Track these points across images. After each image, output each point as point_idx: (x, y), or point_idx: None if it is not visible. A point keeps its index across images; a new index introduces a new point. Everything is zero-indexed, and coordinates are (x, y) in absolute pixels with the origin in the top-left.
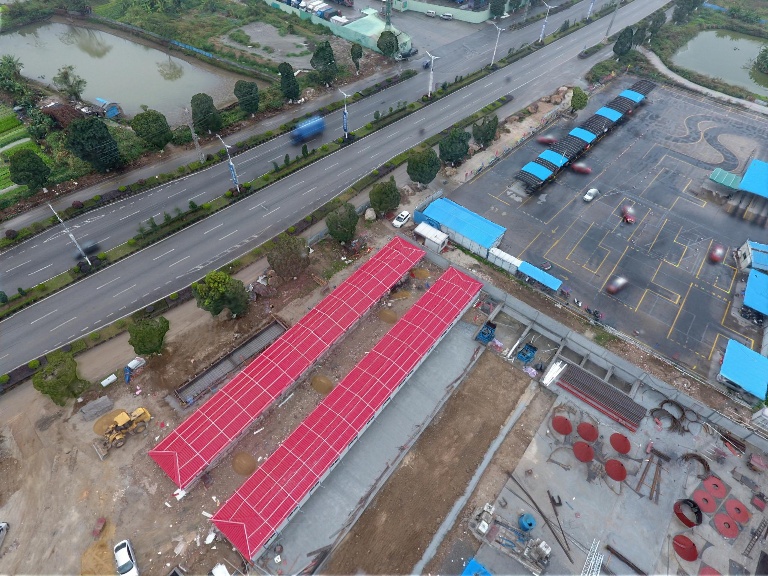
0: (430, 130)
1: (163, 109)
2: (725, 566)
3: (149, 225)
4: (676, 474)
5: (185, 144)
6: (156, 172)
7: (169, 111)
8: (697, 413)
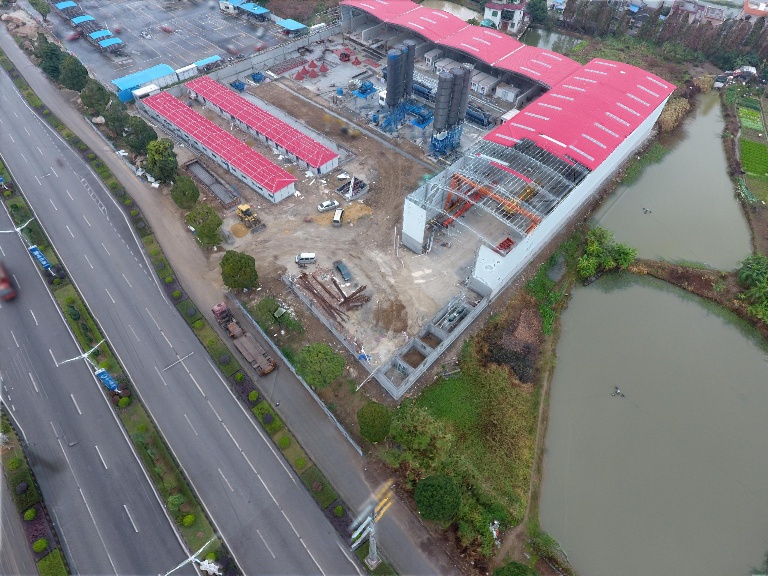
0: (2, 84)
1: None
2: (364, 58)
3: None
4: (330, 57)
5: None
6: None
7: None
8: (306, 45)
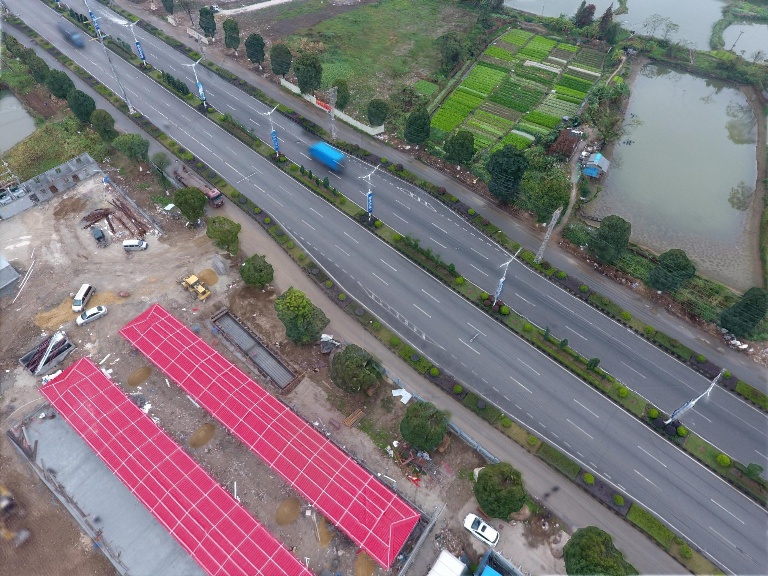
0: None
1: (632, 208)
2: None
3: (414, 242)
4: None
5: (566, 240)
6: (509, 229)
7: (631, 214)
8: None
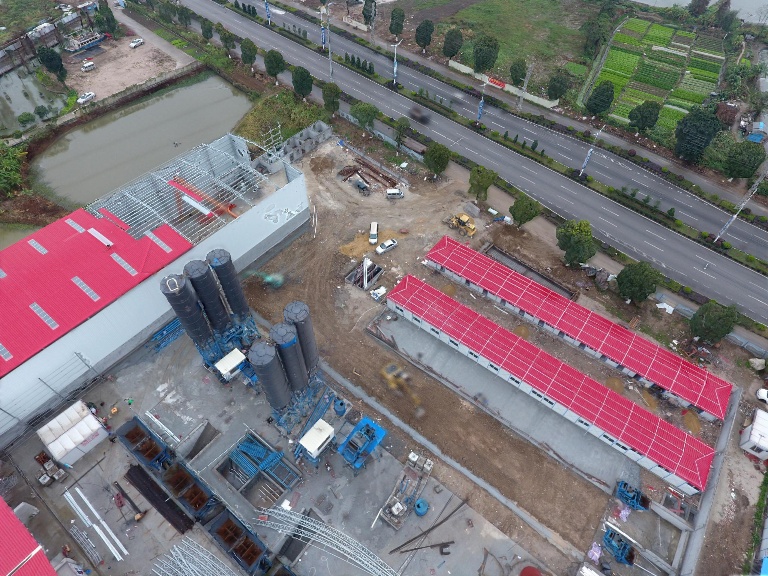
0: None
1: None
2: None
3: (632, 191)
4: None
5: None
6: (700, 184)
7: None
8: None
